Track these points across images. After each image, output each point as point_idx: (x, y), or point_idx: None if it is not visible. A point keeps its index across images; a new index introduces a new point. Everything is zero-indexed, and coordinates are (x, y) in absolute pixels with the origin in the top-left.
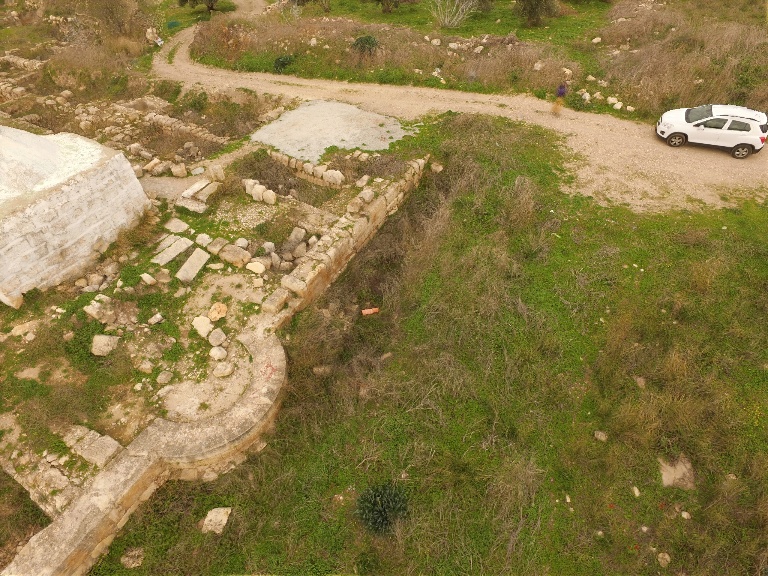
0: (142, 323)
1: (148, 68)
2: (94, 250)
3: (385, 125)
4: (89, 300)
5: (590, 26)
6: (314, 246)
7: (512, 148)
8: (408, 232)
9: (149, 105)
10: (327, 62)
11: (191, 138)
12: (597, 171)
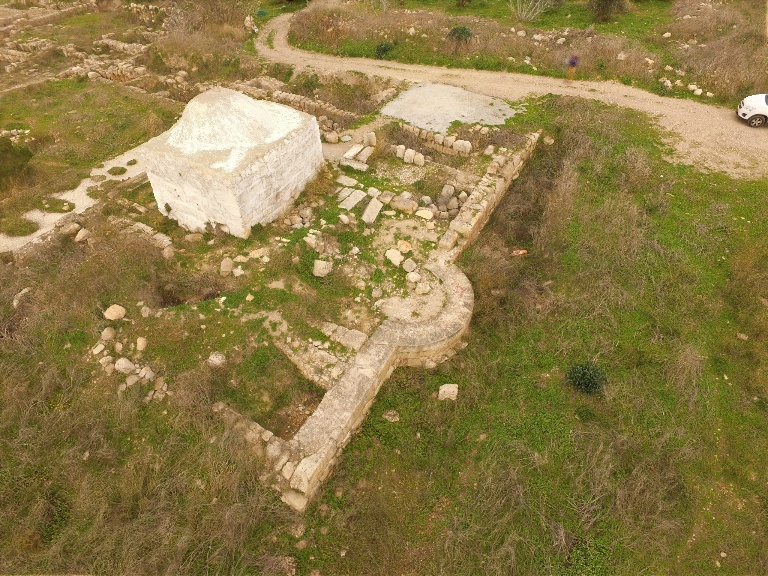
0: (344, 254)
1: (254, 52)
2: (291, 197)
3: (495, 104)
4: (306, 233)
5: (656, 22)
6: (468, 199)
7: (614, 125)
8: (536, 192)
9: (263, 85)
10: (426, 49)
11: (323, 112)
12: (692, 145)
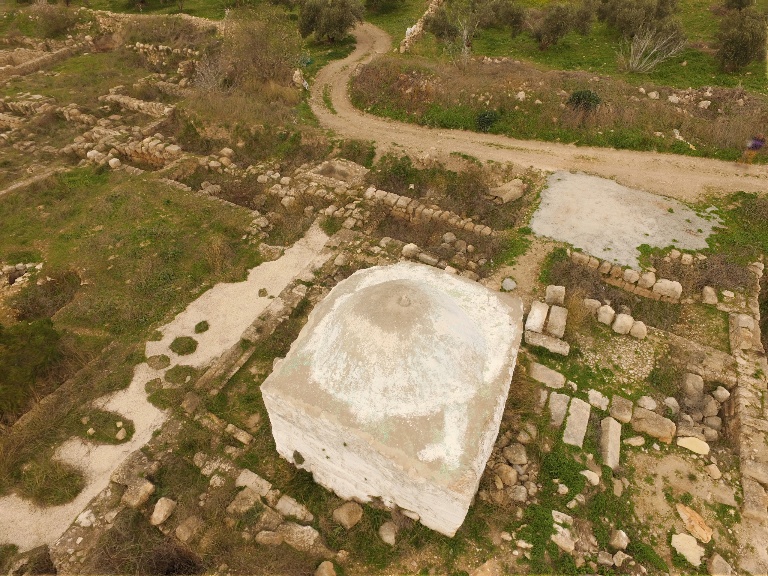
0: (603, 544)
1: (315, 120)
2: None
3: (675, 210)
4: (551, 524)
5: None
6: (741, 407)
7: None
8: None
9: (338, 169)
10: (544, 120)
11: (446, 227)
12: None
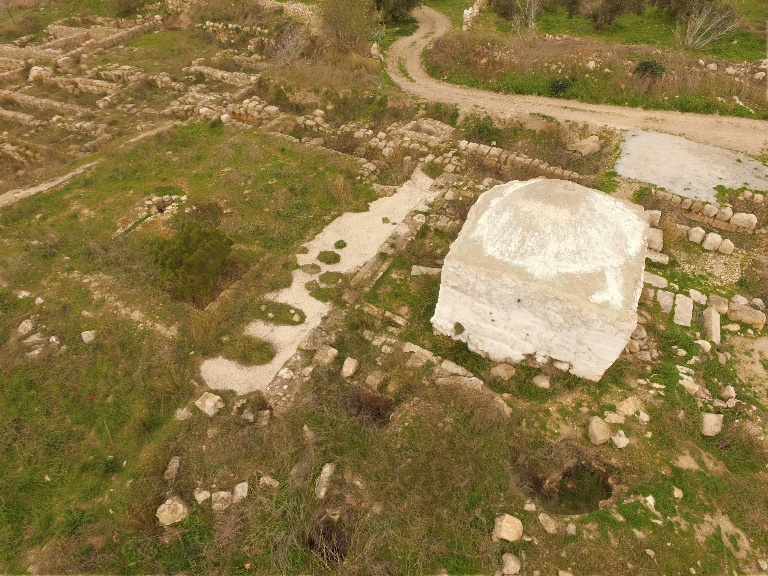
0: (716, 396)
1: (397, 87)
2: None
3: (743, 161)
4: (677, 373)
5: None
6: None
7: None
8: None
9: (424, 128)
10: (613, 87)
11: (538, 171)
12: None
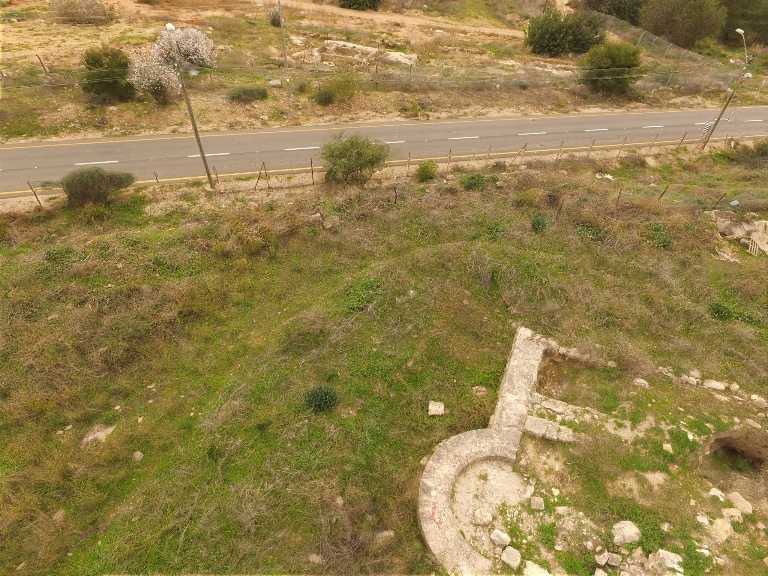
0: (614, 574)
1: None
2: None
3: None
4: (686, 570)
5: None
6: None
7: None
8: None
9: None
10: None
11: None
12: None
